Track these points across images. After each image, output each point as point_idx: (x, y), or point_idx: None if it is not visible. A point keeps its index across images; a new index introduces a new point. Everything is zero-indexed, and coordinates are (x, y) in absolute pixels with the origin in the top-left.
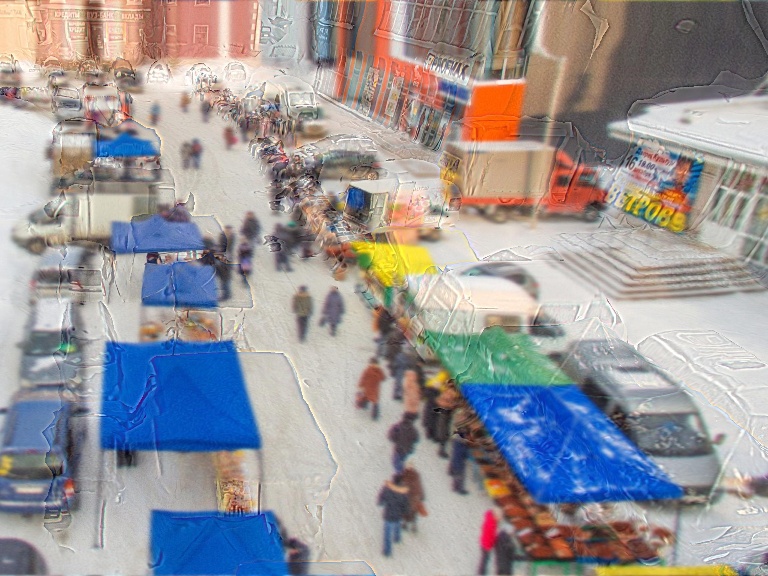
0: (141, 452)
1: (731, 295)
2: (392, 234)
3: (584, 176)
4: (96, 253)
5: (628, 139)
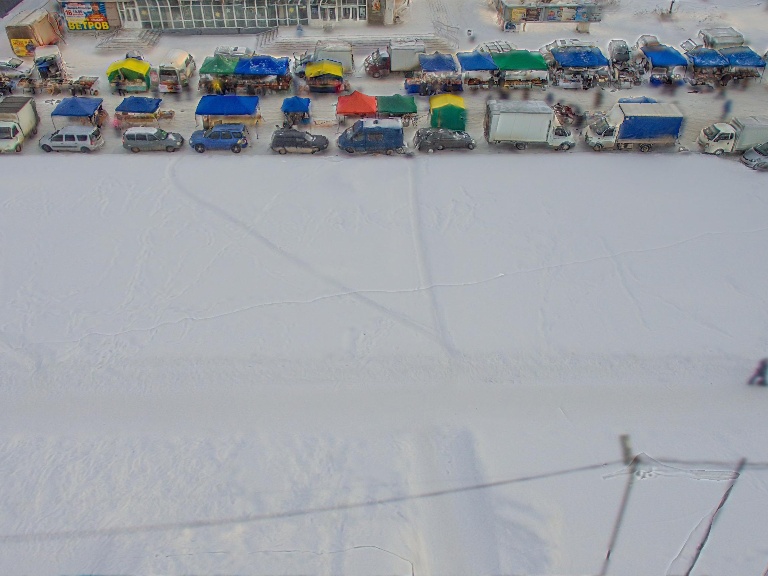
0: (237, 120)
1: (168, 39)
2: (124, 68)
3: (60, 24)
4: (82, 126)
5: (6, 0)
